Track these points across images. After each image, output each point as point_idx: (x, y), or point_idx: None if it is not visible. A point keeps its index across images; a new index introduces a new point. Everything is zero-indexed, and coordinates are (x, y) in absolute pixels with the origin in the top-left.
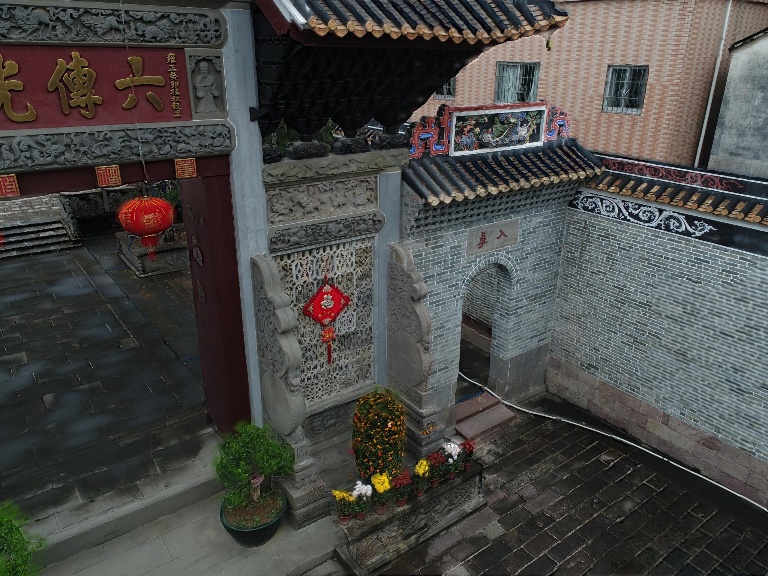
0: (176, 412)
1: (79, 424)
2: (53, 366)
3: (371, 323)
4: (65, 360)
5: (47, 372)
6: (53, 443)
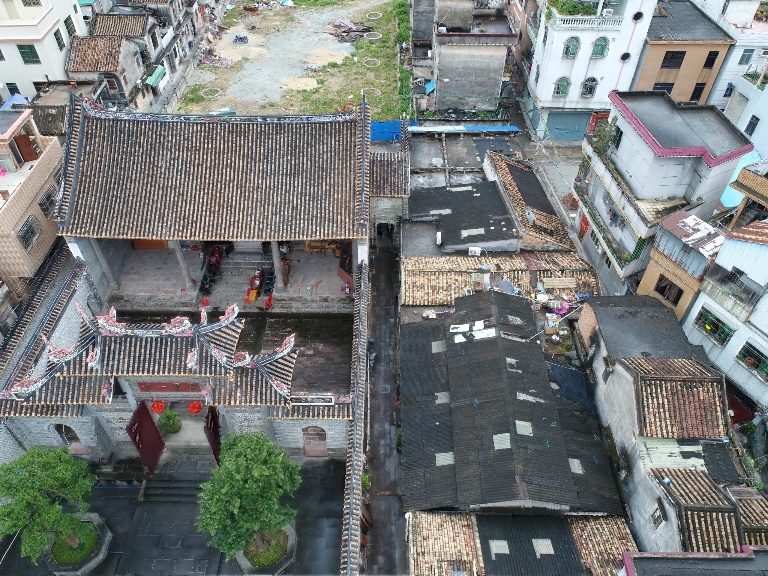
0: (151, 506)
1: (179, 519)
2: (166, 573)
3: (110, 426)
4: (159, 575)
5: (170, 568)
6: (191, 512)
